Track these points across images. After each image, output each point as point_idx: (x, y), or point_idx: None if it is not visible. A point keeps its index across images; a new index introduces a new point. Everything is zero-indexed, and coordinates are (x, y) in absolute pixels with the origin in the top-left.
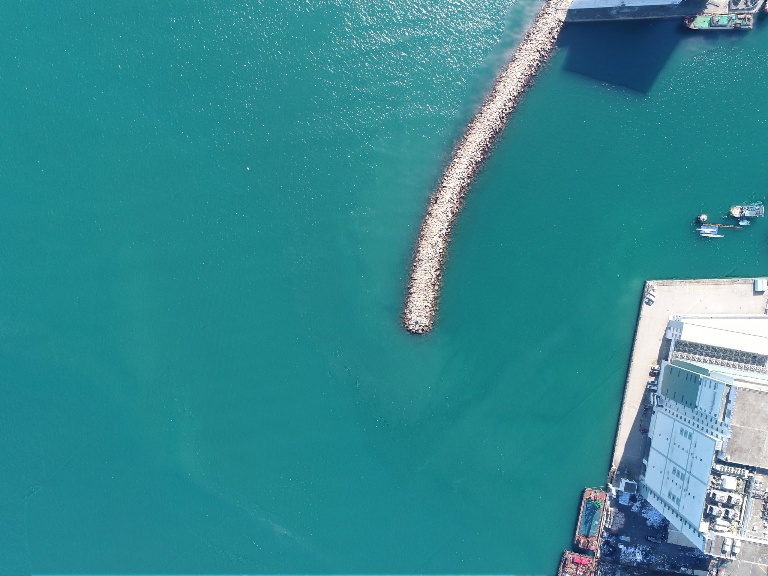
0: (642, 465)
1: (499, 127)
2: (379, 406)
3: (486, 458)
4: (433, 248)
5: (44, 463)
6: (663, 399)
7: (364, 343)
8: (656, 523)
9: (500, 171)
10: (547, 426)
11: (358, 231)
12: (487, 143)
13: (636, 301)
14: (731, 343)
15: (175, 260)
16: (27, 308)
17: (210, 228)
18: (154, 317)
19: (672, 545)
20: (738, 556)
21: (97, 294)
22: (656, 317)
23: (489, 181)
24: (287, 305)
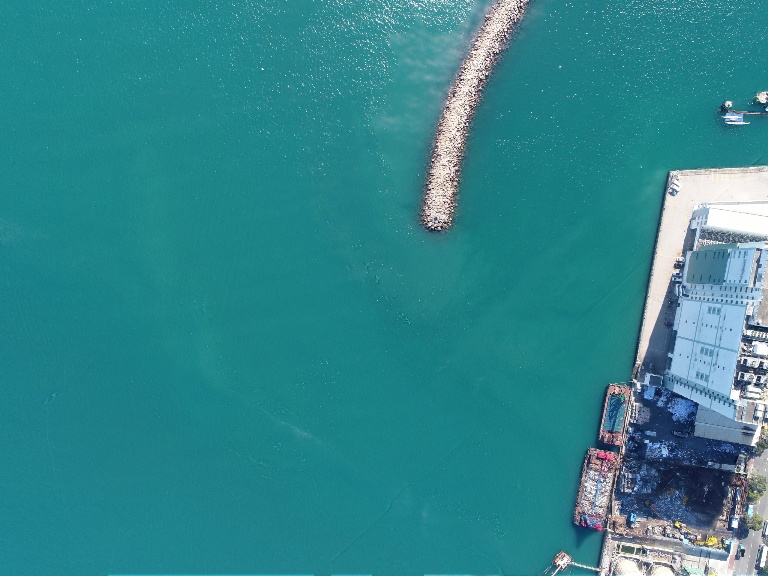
0: (667, 359)
1: (517, 17)
2: (399, 299)
3: (508, 356)
4: (451, 142)
5: (64, 369)
6: (689, 288)
7: (383, 235)
8: (682, 418)
9: (519, 63)
10: (569, 322)
11: (375, 129)
12: (505, 34)
13: (659, 193)
14: (759, 227)
15: (191, 154)
16: (44, 214)
17: (226, 121)
18: (171, 214)
19: (699, 440)
20: None
21: (114, 196)
22: (680, 208)
23: (507, 74)
24: (305, 197)
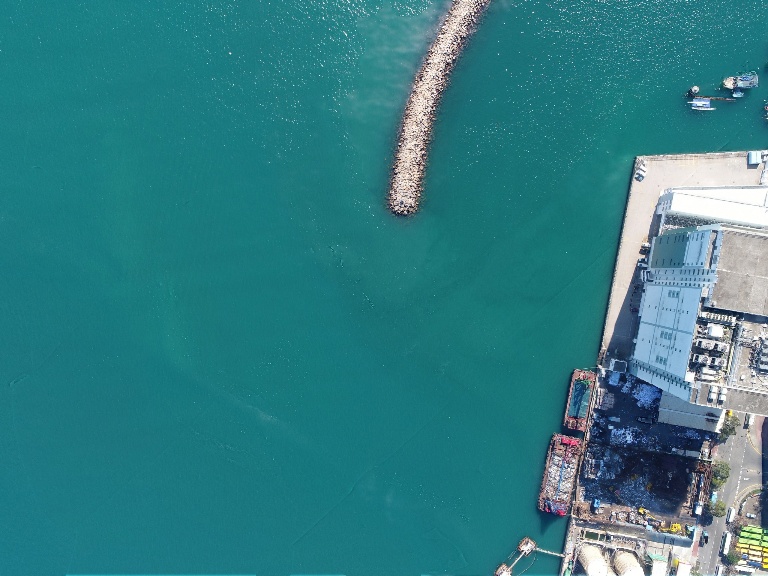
0: (632, 345)
1: (485, 1)
2: (363, 282)
3: (473, 341)
4: (418, 126)
5: (32, 351)
6: (653, 274)
7: (347, 218)
8: (647, 404)
9: (486, 48)
10: (535, 307)
11: (342, 113)
12: (472, 18)
13: (626, 178)
14: (723, 212)
15: (156, 135)
16: (13, 196)
17: (191, 102)
18: (137, 196)
19: (663, 426)
20: (725, 405)
21: (81, 178)
22: (646, 193)
23: (475, 59)
24: (269, 180)
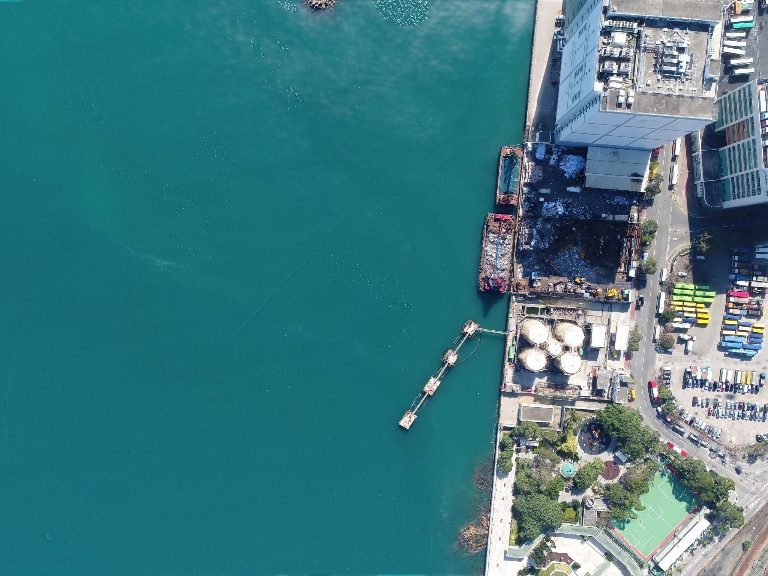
0: None
1: None
2: (284, 68)
3: (402, 131)
4: None
5: None
6: (568, 39)
7: (263, 4)
8: (574, 174)
9: None
10: (459, 91)
11: None
12: None
13: None
14: None
15: None
16: None
17: None
18: None
19: (592, 195)
20: (633, 109)
21: None
22: None
23: None
24: None
